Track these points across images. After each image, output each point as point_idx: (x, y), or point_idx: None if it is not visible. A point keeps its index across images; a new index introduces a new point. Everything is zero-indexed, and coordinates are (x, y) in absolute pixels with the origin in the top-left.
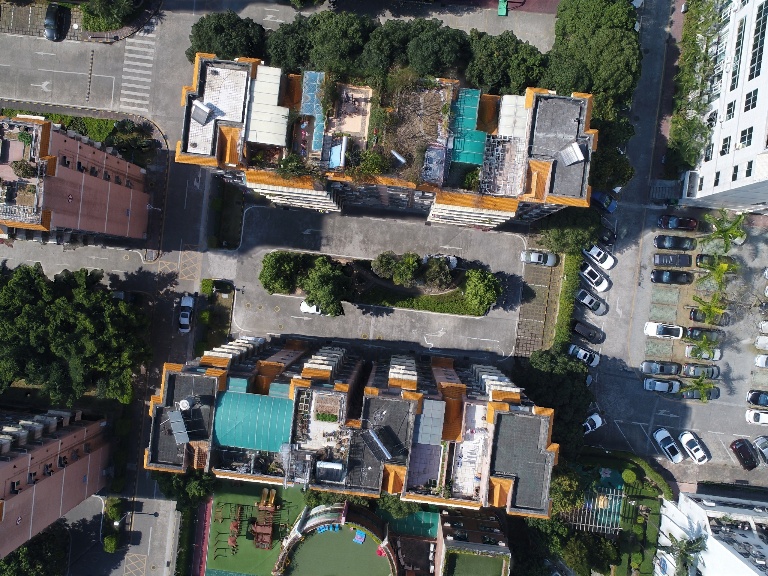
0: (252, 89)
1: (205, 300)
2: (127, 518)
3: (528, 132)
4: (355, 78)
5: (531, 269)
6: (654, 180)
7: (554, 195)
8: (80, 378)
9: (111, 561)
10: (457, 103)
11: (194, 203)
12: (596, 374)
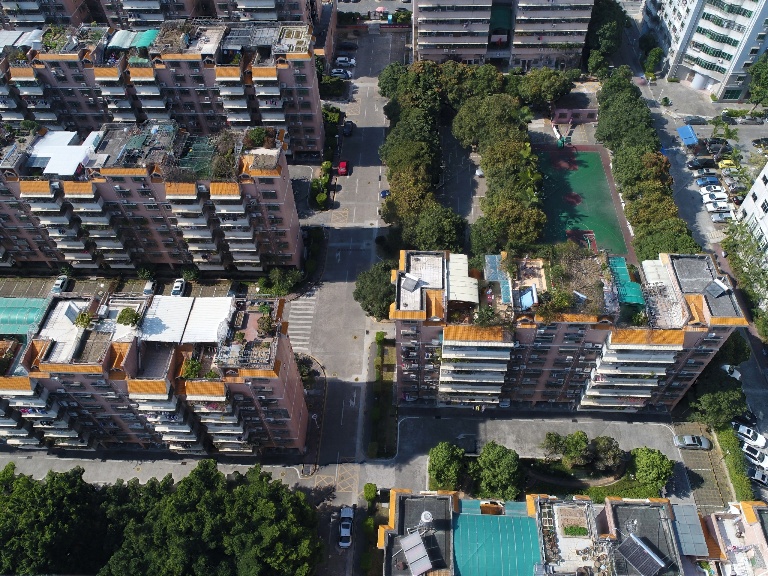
0: (448, 267)
1: (364, 511)
2: None
3: (674, 278)
4: (528, 254)
5: (688, 454)
6: (765, 369)
7: (716, 317)
8: (257, 570)
9: None
10: (610, 266)
11: (350, 419)
12: None
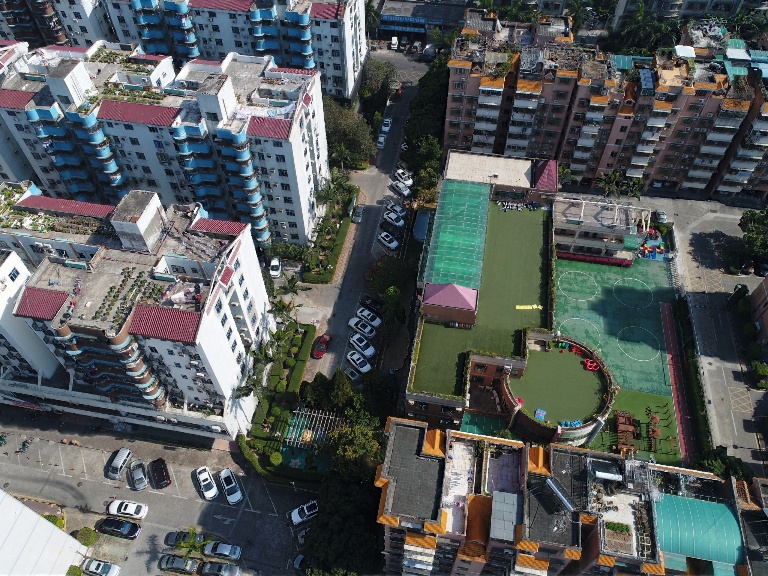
0: None
1: None
2: (764, 445)
3: None
4: None
5: None
6: None
7: None
8: None
9: (766, 407)
10: None
11: None
12: (288, 568)
